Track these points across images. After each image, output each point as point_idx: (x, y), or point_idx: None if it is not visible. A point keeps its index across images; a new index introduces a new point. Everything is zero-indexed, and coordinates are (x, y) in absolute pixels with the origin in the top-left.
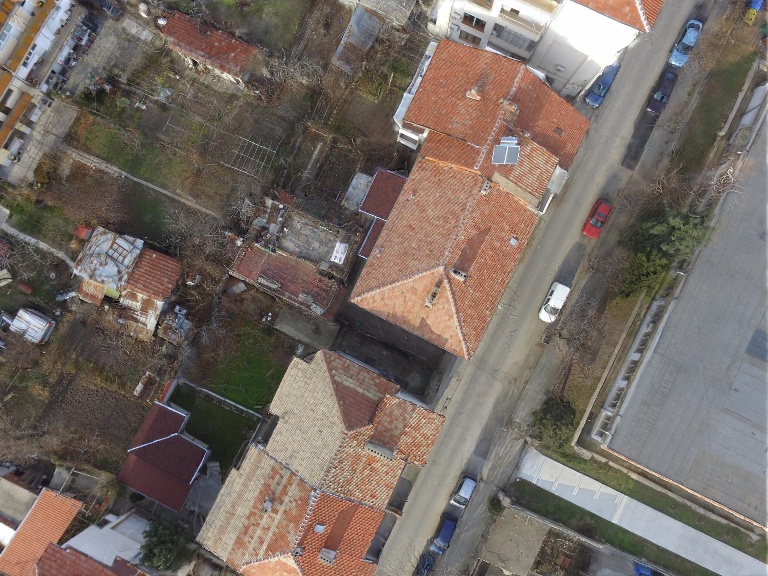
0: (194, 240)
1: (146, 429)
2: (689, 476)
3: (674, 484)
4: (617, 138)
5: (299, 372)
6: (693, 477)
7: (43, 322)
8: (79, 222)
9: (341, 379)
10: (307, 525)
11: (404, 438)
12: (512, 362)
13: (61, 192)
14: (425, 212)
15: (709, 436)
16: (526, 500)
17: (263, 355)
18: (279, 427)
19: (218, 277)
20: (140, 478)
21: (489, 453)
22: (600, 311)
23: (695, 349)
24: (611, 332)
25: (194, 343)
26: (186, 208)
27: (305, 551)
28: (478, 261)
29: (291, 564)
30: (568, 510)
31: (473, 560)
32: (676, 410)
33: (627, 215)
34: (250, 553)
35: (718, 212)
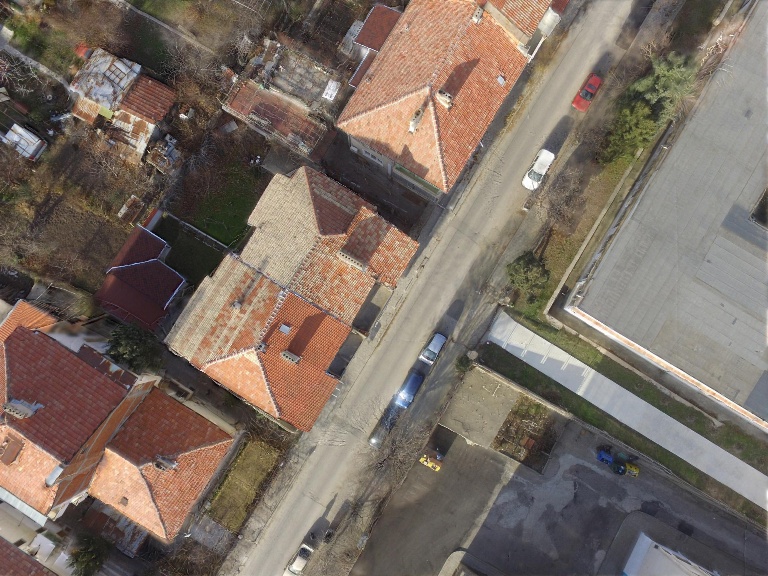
0: (191, 72)
1: (126, 250)
2: (656, 342)
3: (642, 364)
4: (614, 17)
5: (280, 186)
6: (659, 343)
7: (36, 137)
8: (80, 43)
9: (320, 192)
10: (273, 322)
11: (376, 256)
12: (492, 227)
13: (66, 17)
14: (417, 41)
15: (679, 304)
16: (494, 363)
17: (248, 196)
18: (255, 236)
19: (211, 111)
20: (116, 295)
21: (462, 315)
22: (583, 185)
23: (672, 218)
24: (592, 207)
25: (181, 174)
26: (186, 44)
27: (269, 349)
28: (464, 91)
29: (254, 361)
30: (535, 377)
31: (436, 415)
32: (648, 276)
33: (617, 92)
34: (215, 351)
35: (705, 88)
